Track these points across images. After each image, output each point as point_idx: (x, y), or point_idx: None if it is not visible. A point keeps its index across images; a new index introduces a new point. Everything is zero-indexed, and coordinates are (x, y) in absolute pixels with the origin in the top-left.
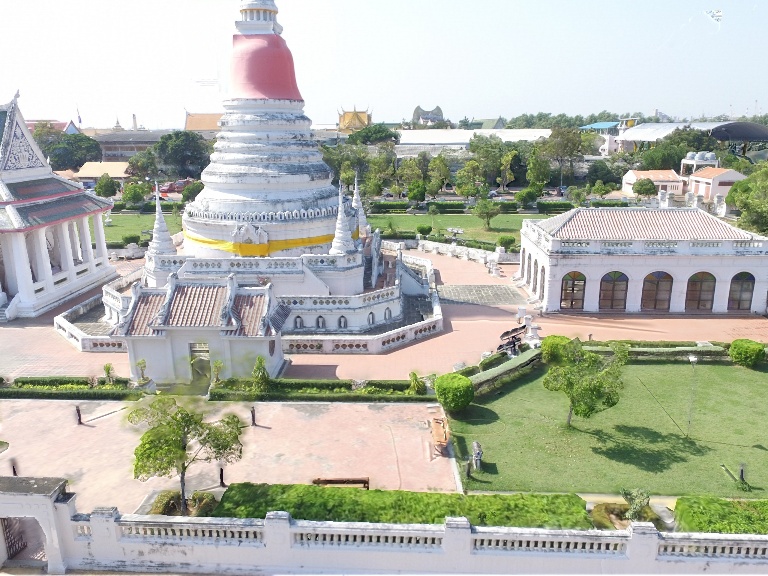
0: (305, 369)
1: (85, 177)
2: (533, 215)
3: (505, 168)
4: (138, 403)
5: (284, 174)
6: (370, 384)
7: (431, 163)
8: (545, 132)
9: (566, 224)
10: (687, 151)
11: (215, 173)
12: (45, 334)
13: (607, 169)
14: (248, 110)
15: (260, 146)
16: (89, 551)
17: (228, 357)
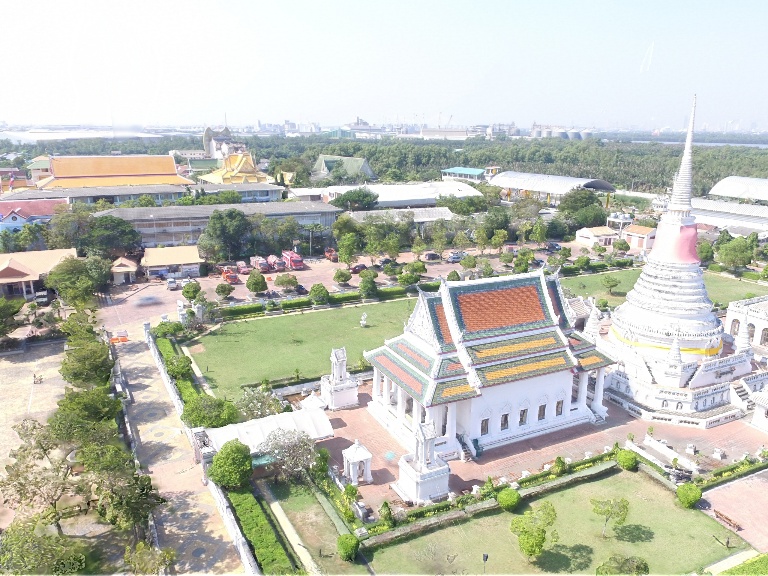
0: None
1: (158, 266)
2: (594, 275)
3: (522, 233)
4: None
5: None
6: None
7: (476, 233)
8: (464, 186)
9: None
10: None
11: (680, 308)
12: None
13: None
14: (691, 270)
15: (701, 290)
16: None
17: None
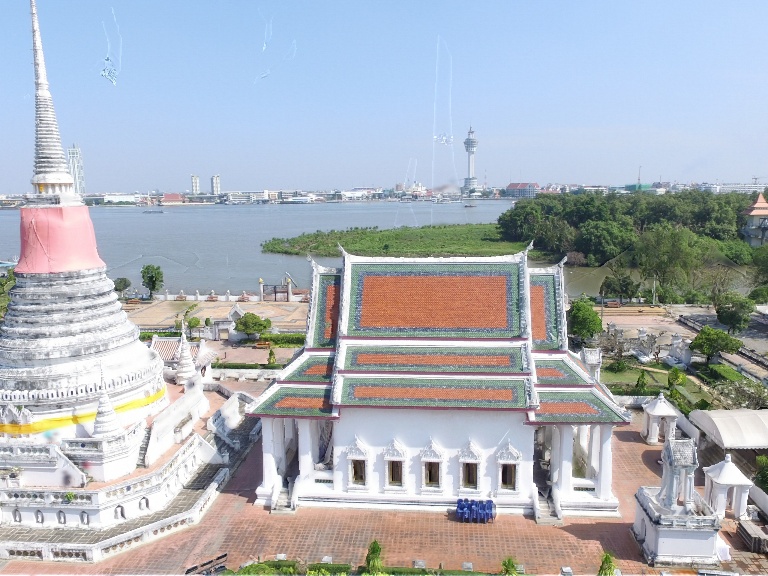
0: None
1: None
2: None
3: None
4: None
5: None
6: None
7: None
8: None
9: None
10: None
11: None
12: None
13: None
14: None
15: None
16: None
17: None
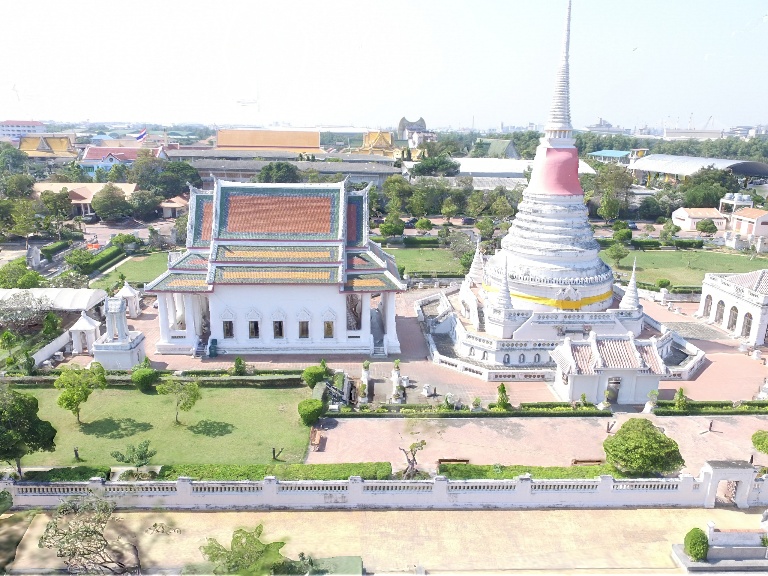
0: (659, 392)
1: None
2: (632, 251)
3: None
4: (617, 418)
5: (586, 250)
6: (744, 403)
7: (521, 200)
8: None
9: (760, 282)
10: (721, 191)
11: (533, 248)
12: (434, 367)
13: (657, 205)
14: (558, 203)
15: (569, 229)
16: (758, 497)
17: (634, 387)
